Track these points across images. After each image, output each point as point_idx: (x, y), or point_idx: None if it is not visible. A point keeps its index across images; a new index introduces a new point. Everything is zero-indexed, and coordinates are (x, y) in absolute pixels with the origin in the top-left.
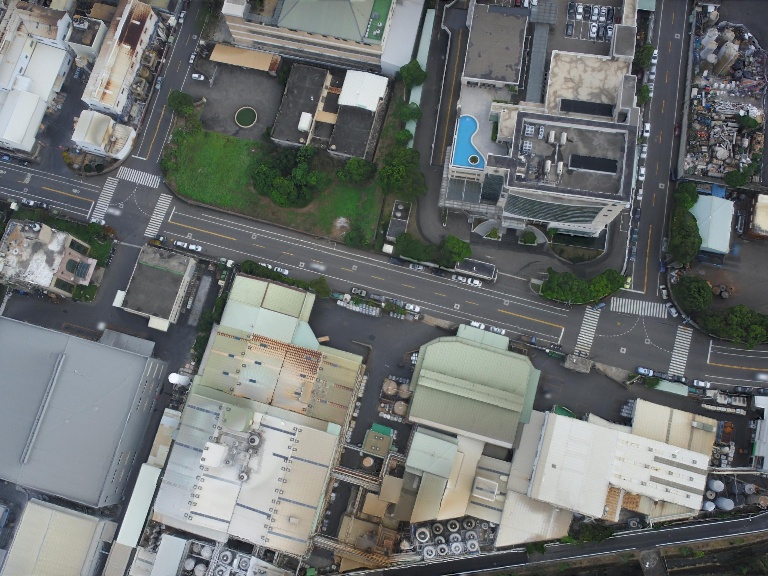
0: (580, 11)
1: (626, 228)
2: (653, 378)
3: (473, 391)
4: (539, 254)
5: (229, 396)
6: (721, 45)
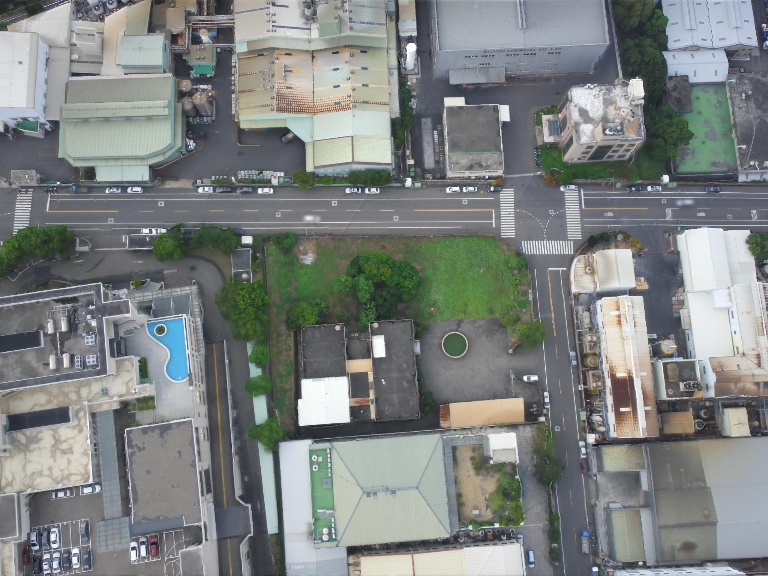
0: (75, 558)
1: None
2: None
3: (113, 108)
4: (88, 280)
5: (348, 42)
6: None
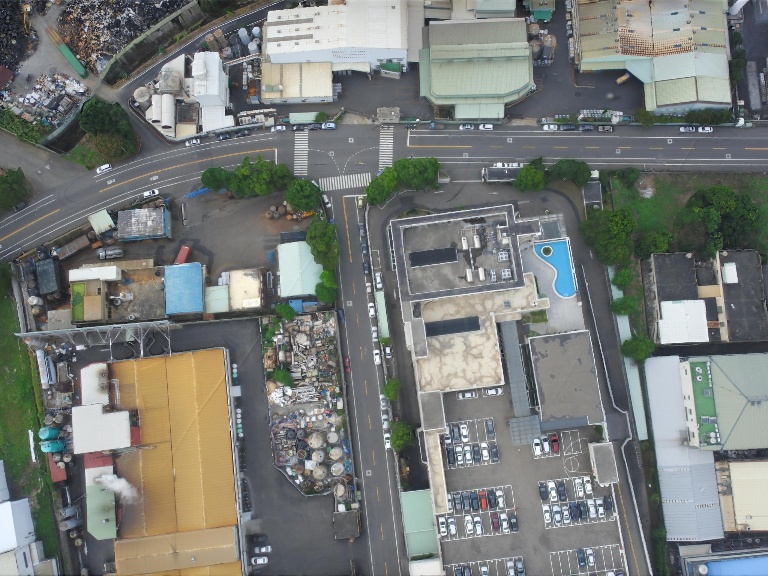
0: (485, 451)
1: (374, 254)
2: (321, 121)
3: (478, 49)
4: (448, 209)
5: None
6: (324, 463)
